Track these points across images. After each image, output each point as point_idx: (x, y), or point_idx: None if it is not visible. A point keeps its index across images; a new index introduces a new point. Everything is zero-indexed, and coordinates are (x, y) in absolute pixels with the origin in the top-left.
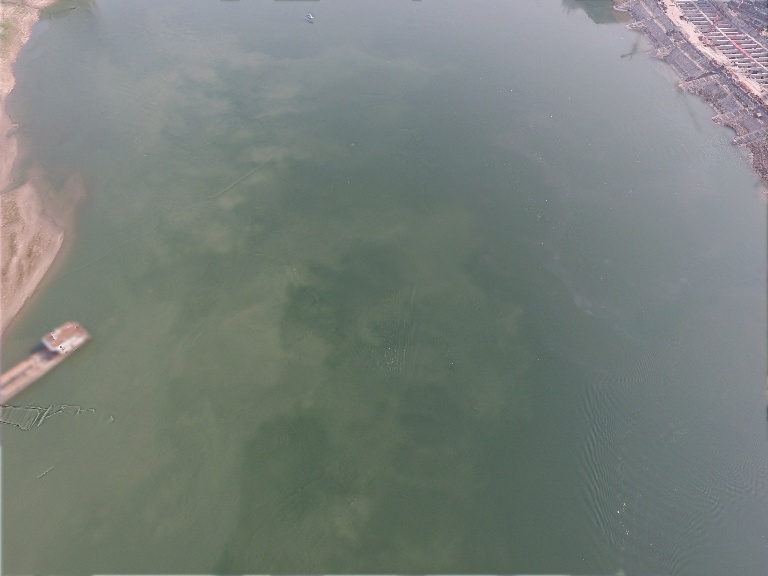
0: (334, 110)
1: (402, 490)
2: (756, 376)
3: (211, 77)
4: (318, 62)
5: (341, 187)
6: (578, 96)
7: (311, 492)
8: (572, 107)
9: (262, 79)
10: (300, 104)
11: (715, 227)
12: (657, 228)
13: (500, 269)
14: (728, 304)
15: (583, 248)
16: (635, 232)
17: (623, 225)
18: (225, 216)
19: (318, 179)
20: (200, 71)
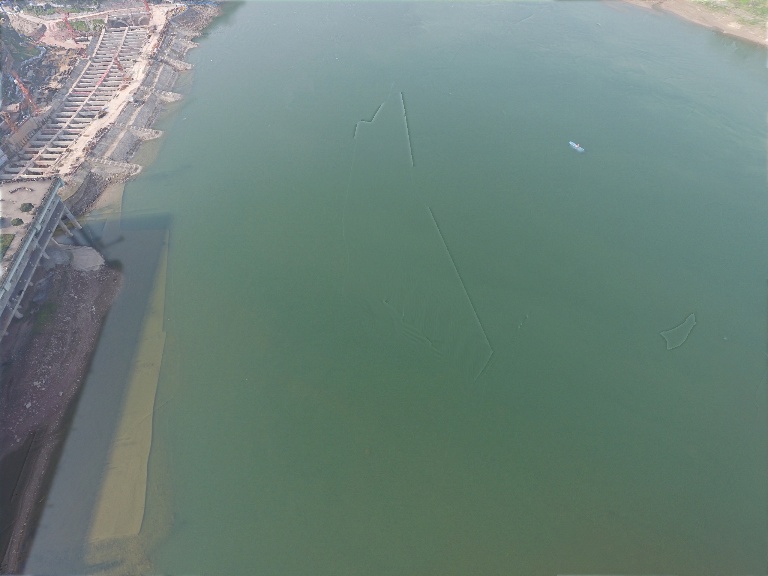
0: (485, 52)
1: None
2: None
3: (622, 77)
4: (525, 91)
5: (457, 4)
6: (283, 60)
7: None
8: (294, 52)
9: (570, 77)
10: (517, 59)
11: (261, 4)
12: (291, 3)
13: None
14: None
15: None
16: (303, 1)
17: None
18: (518, 7)
19: (475, 20)
20: (639, 78)
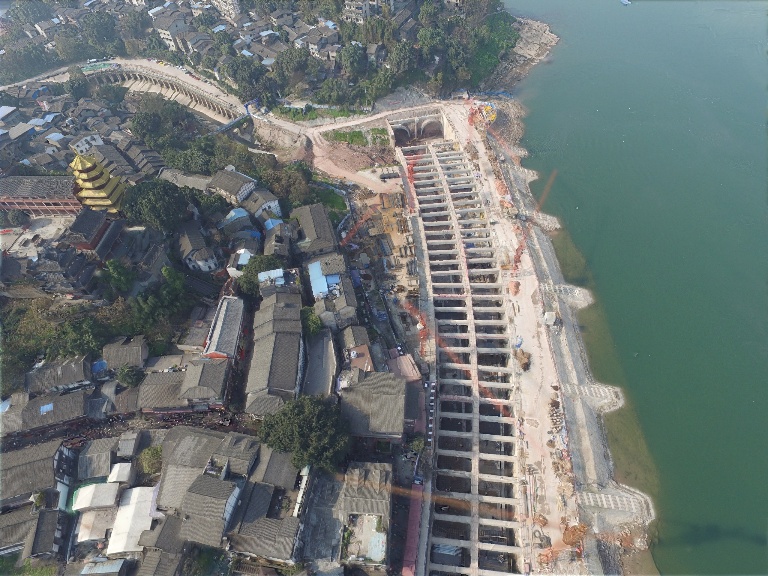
0: None
1: (728, 23)
2: (576, 45)
3: None
4: None
5: None
6: (696, 213)
7: (767, 12)
8: (700, 195)
9: None
10: None
11: (573, 94)
12: (615, 93)
13: (721, 72)
14: (579, 64)
15: (668, 82)
16: (631, 90)
17: (640, 93)
18: None
19: None
20: None
